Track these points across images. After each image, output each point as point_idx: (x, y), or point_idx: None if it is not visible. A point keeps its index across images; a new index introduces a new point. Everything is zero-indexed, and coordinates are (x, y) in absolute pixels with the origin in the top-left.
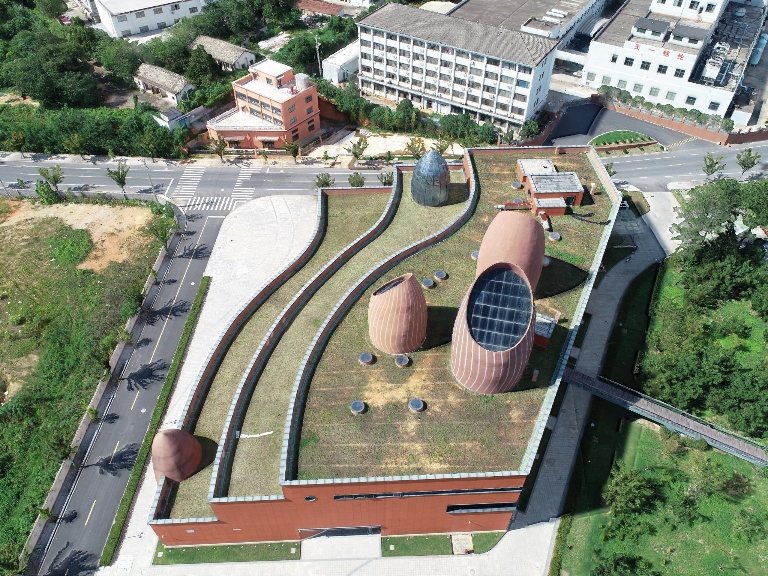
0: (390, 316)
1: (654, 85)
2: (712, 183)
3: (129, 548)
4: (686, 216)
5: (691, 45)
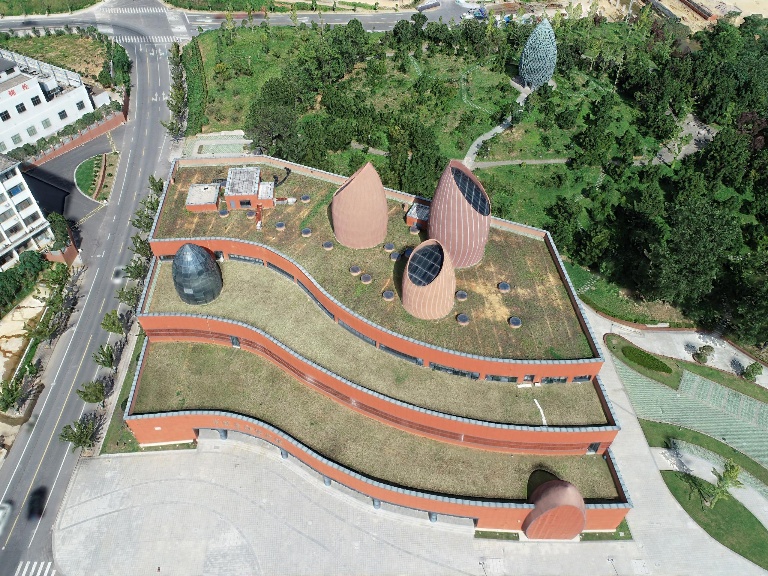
0: (453, 273)
1: (26, 126)
2: (256, 109)
3: (626, 568)
4: (257, 145)
5: (11, 75)
